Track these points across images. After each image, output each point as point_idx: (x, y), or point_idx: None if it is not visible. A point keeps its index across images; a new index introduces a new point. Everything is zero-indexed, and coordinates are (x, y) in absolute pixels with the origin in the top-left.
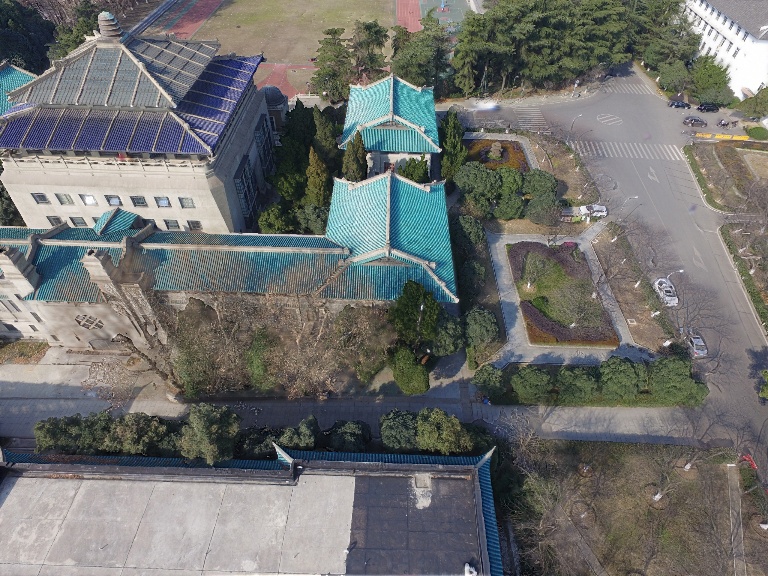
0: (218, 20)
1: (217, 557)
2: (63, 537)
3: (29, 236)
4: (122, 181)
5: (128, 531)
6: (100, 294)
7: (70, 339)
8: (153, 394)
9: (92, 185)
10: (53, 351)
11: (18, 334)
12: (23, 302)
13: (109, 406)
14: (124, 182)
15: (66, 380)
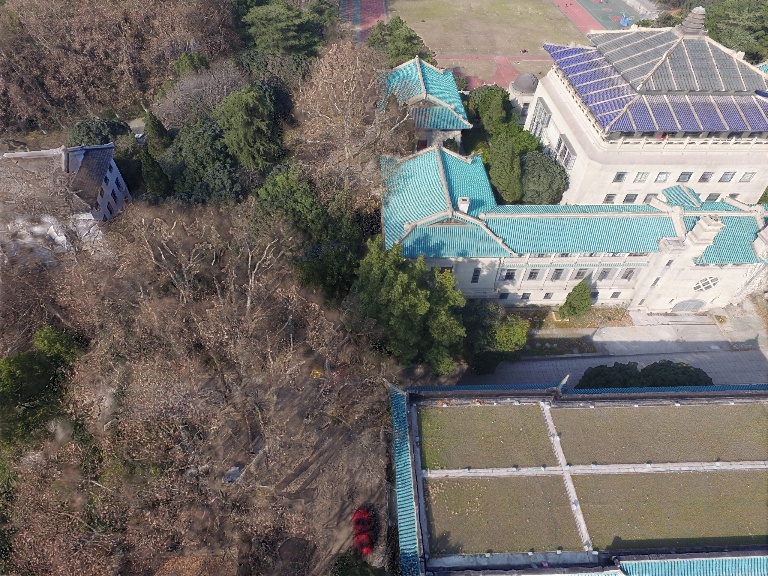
0: None
1: None
2: None
3: (681, 208)
4: (706, 159)
5: None
6: (756, 256)
7: (664, 302)
8: None
9: (680, 163)
10: (635, 314)
11: (593, 301)
12: (666, 267)
13: (744, 356)
14: (708, 160)
15: (680, 337)
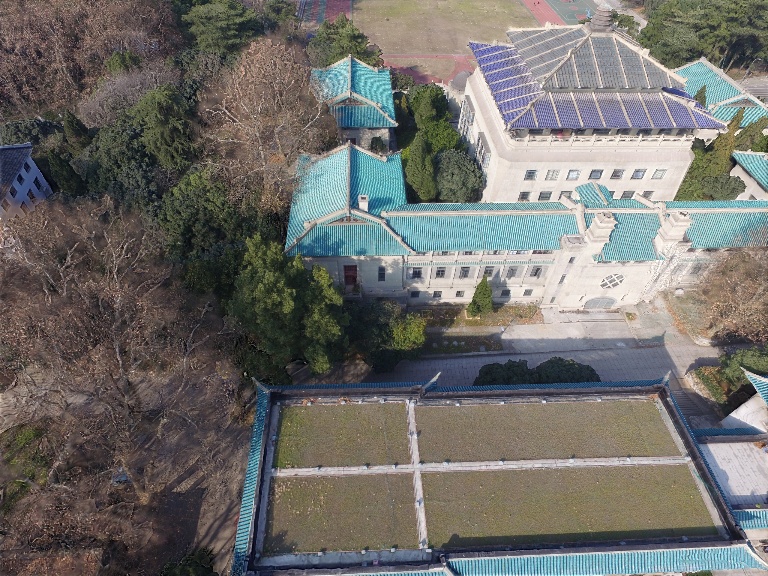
0: (362, 13)
1: None
2: None
3: (582, 205)
4: (615, 156)
5: None
6: (656, 253)
7: (574, 299)
8: (677, 341)
9: (589, 160)
10: (547, 312)
11: (506, 299)
12: (569, 265)
13: (648, 353)
14: (617, 157)
15: (587, 334)
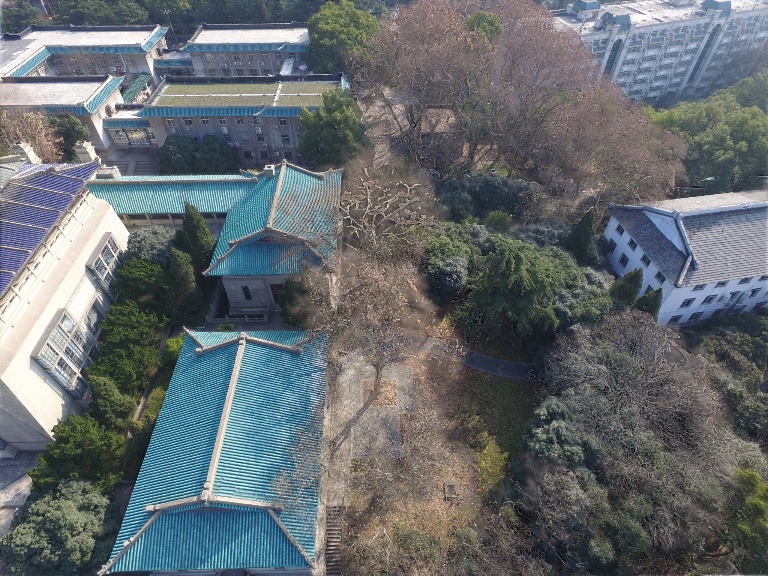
0: None
1: (4, 96)
2: (61, 98)
3: None
4: None
5: (36, 99)
6: None
7: None
8: None
9: None
10: None
11: None
12: None
13: None
14: None
15: None
